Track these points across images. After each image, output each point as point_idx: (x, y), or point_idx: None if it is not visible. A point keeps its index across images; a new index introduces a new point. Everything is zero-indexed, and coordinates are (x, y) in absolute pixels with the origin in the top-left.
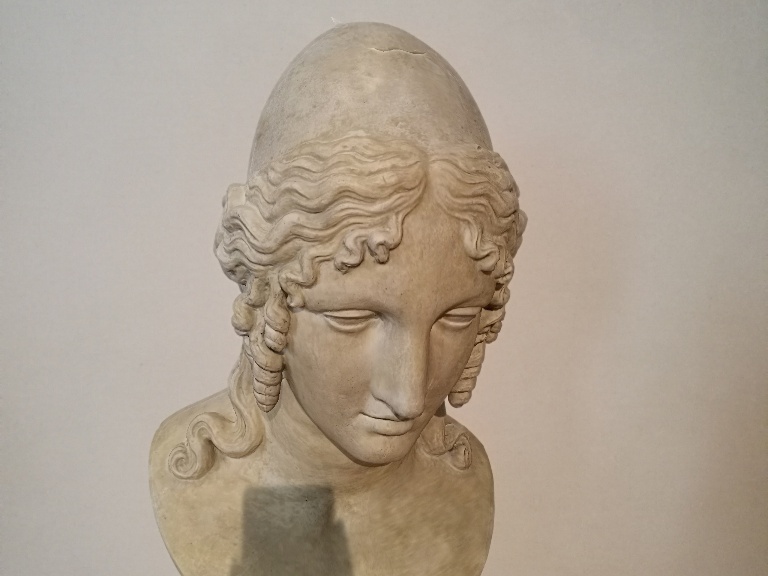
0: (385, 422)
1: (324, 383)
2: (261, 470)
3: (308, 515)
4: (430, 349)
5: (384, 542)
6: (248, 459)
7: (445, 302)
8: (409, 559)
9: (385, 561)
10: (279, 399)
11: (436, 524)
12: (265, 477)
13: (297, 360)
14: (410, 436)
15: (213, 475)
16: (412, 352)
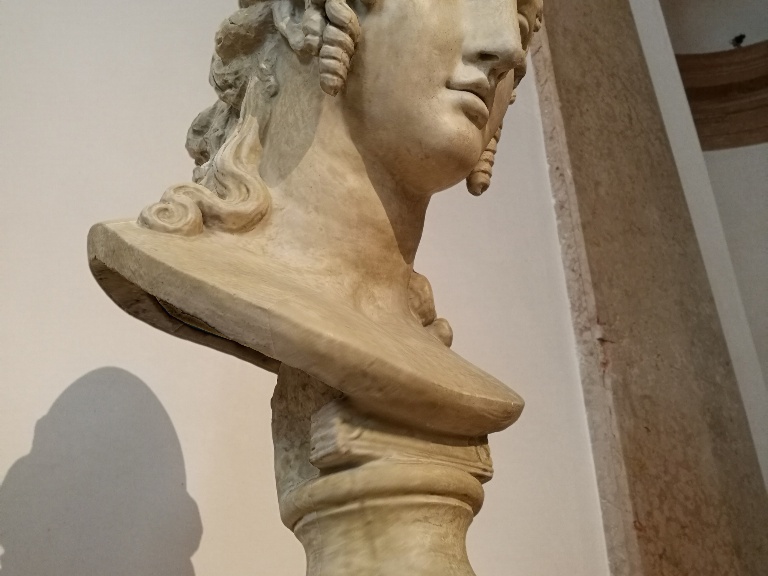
0: (472, 94)
1: (419, 34)
2: (265, 246)
3: (335, 289)
4: None
5: (422, 337)
6: (244, 237)
7: None
8: None
9: (434, 345)
10: (311, 135)
11: None
12: (271, 252)
13: (386, 17)
14: None
15: (205, 239)
16: (510, 1)
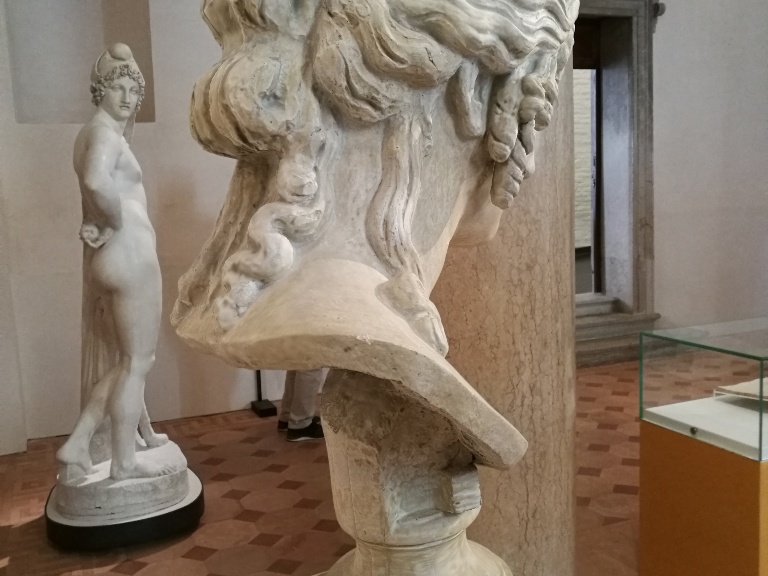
0: None
1: None
2: None
3: None
4: None
5: None
6: None
7: None
8: None
9: None
10: (449, 215)
11: None
12: None
13: None
14: None
15: None
16: None
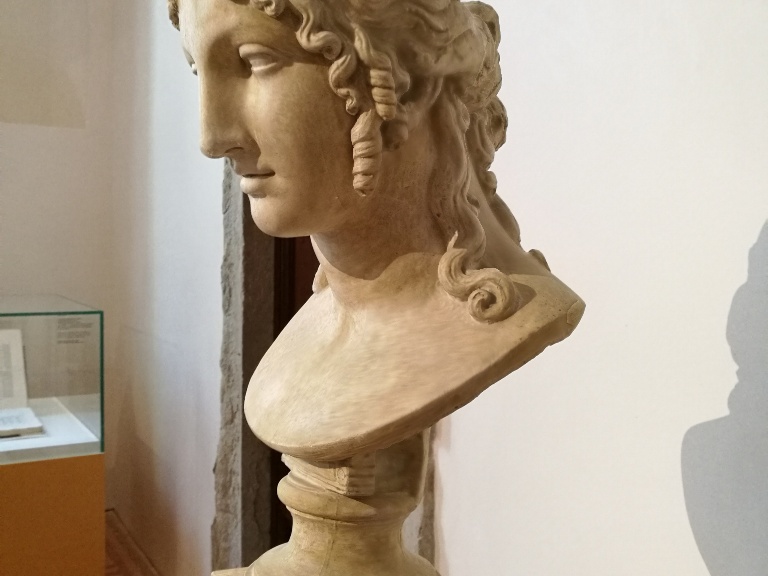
0: (242, 179)
1: None
2: None
3: None
4: (239, 96)
5: (355, 361)
6: None
7: (206, 36)
8: (356, 380)
9: (341, 375)
10: None
11: (405, 360)
12: None
13: None
14: (274, 202)
15: None
16: None
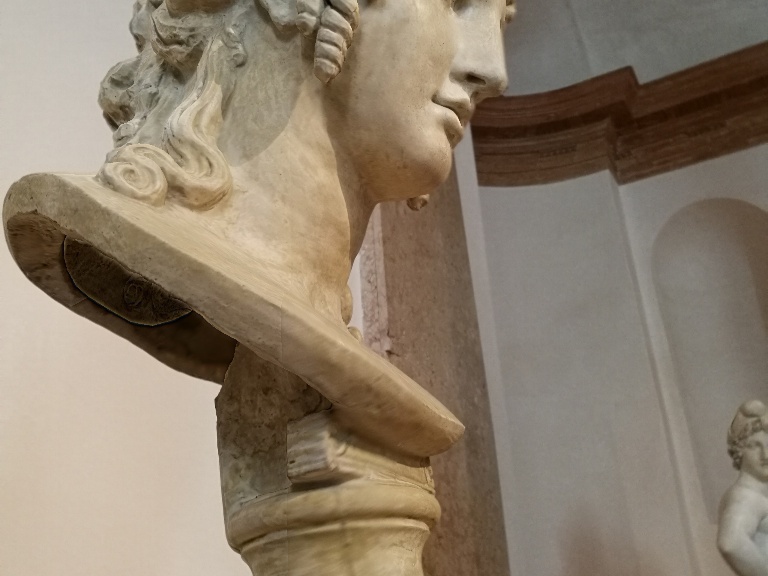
0: (454, 113)
1: (418, 40)
2: (225, 229)
3: (297, 288)
4: None
5: None
6: (203, 216)
7: (504, 11)
8: None
9: None
10: (285, 118)
11: None
12: (233, 238)
13: (387, 15)
14: None
15: (170, 212)
16: (498, 29)
